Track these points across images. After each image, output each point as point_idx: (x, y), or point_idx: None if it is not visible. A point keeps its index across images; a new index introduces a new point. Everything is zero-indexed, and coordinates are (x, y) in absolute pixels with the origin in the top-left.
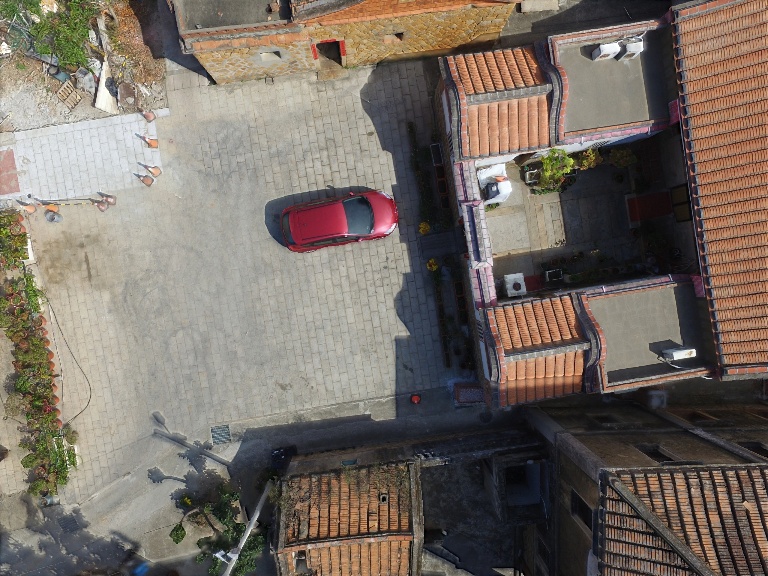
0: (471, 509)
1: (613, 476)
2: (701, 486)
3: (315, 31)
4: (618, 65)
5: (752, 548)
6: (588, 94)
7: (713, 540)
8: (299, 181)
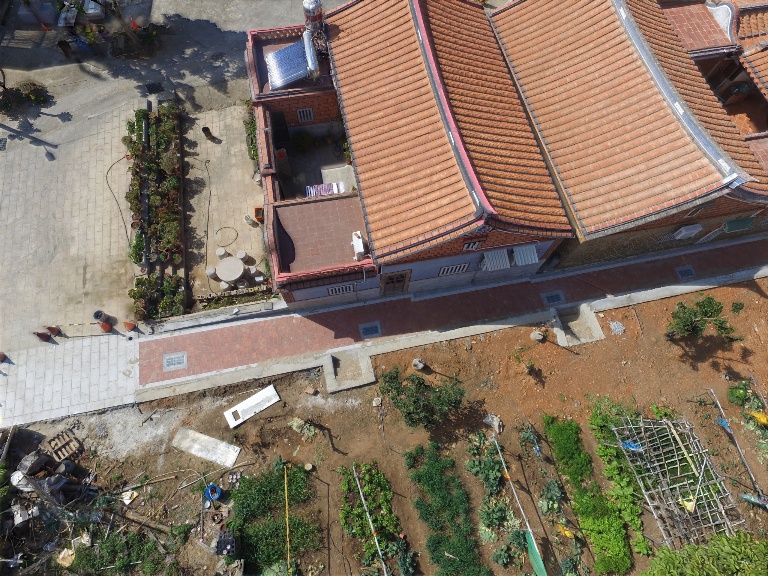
0: None
1: None
2: None
3: None
4: None
5: None
6: None
7: None
8: None
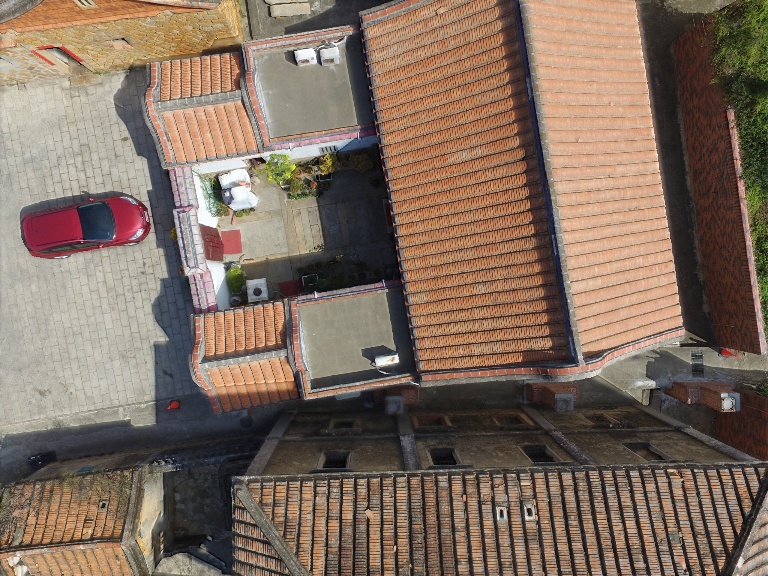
0: None
1: (238, 484)
2: (328, 494)
3: (18, 37)
4: (324, 70)
5: (361, 557)
6: (294, 100)
7: (326, 549)
8: (54, 187)
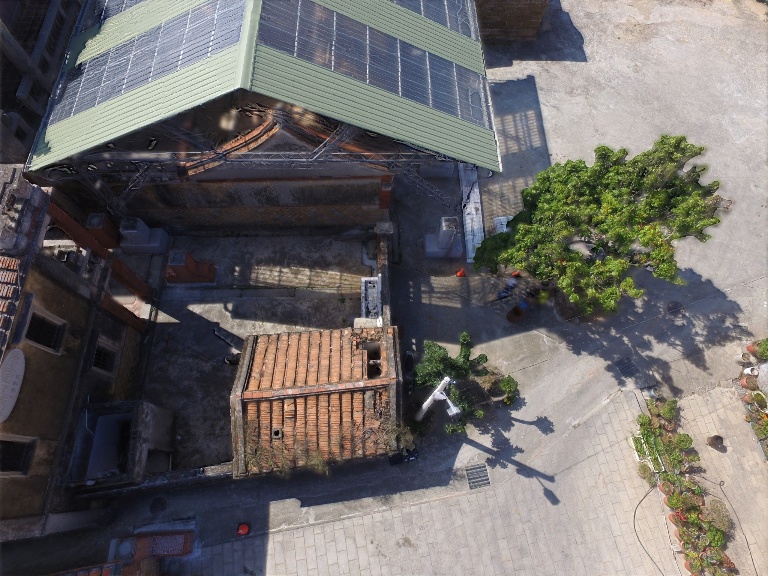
0: (194, 387)
1: None
2: None
3: None
4: None
5: None
6: None
7: None
8: None
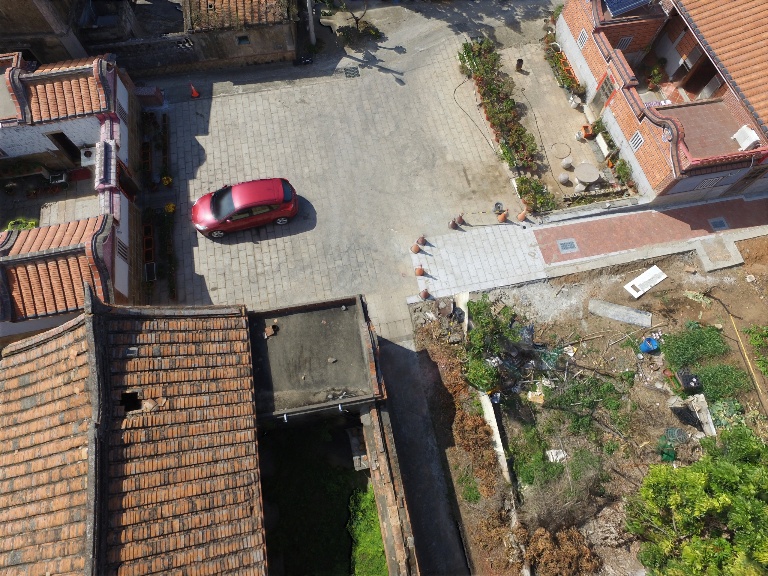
0: None
1: None
2: None
3: None
4: None
5: None
6: None
7: None
8: (285, 246)
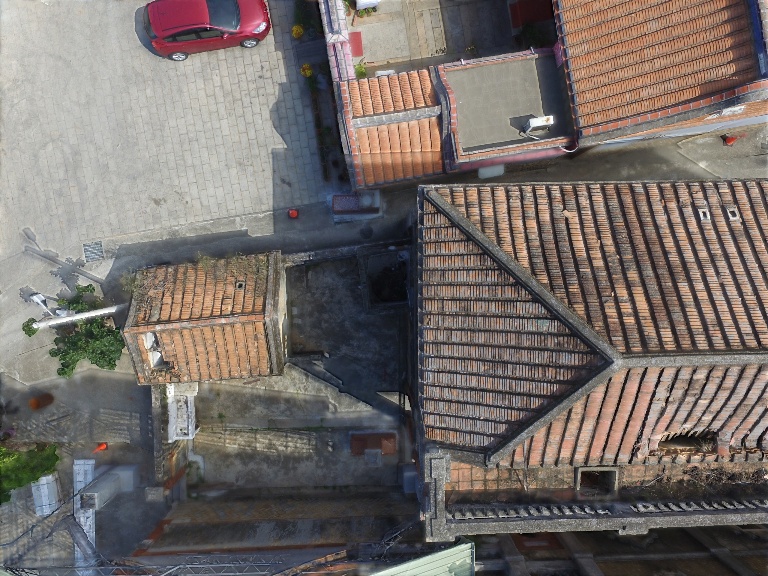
0: (354, 330)
1: None
2: (521, 198)
3: None
4: None
5: (565, 248)
6: None
7: (527, 244)
8: None
